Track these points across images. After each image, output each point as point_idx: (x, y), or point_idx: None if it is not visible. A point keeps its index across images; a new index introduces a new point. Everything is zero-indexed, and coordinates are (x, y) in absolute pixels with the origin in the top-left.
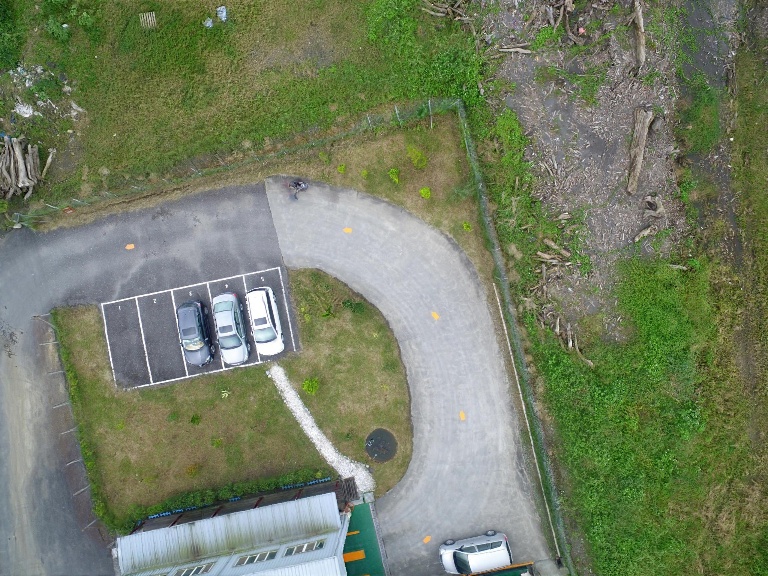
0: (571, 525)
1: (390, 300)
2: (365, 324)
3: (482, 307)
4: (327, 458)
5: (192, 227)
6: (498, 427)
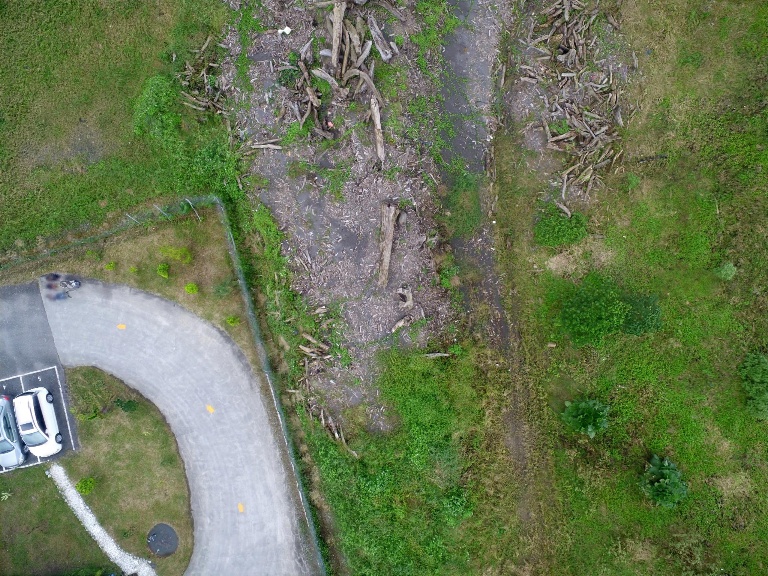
0: None
1: (166, 395)
2: (142, 420)
3: (255, 399)
4: (110, 555)
5: None
6: (276, 518)
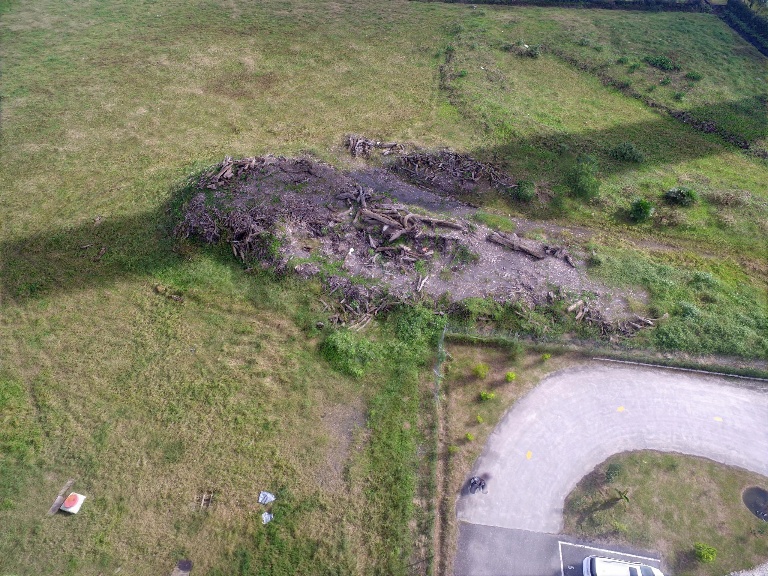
0: None
1: (604, 441)
2: (628, 473)
3: (614, 372)
4: None
5: None
6: (725, 395)
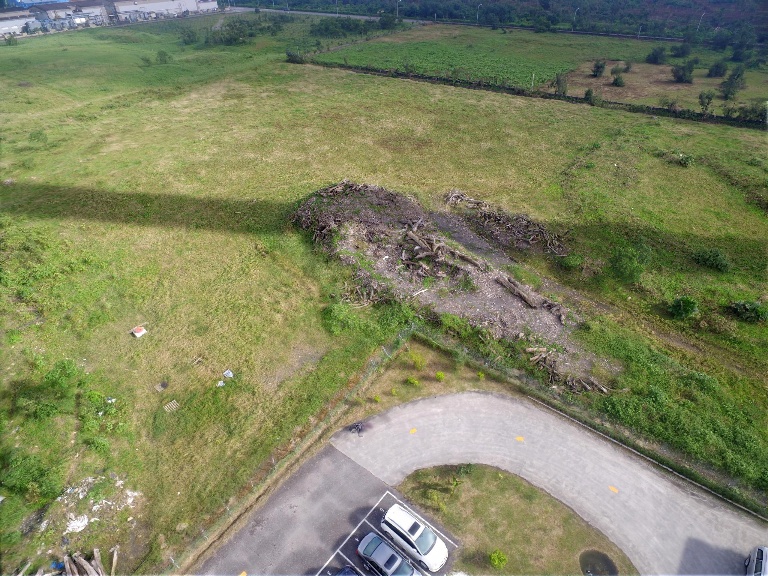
0: (767, 503)
1: (483, 452)
2: (485, 481)
3: (538, 412)
4: None
5: (293, 515)
6: (640, 477)
